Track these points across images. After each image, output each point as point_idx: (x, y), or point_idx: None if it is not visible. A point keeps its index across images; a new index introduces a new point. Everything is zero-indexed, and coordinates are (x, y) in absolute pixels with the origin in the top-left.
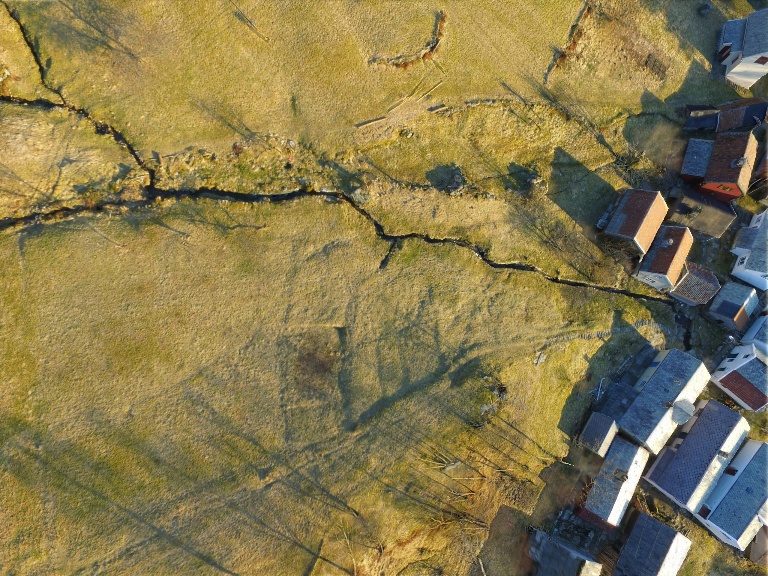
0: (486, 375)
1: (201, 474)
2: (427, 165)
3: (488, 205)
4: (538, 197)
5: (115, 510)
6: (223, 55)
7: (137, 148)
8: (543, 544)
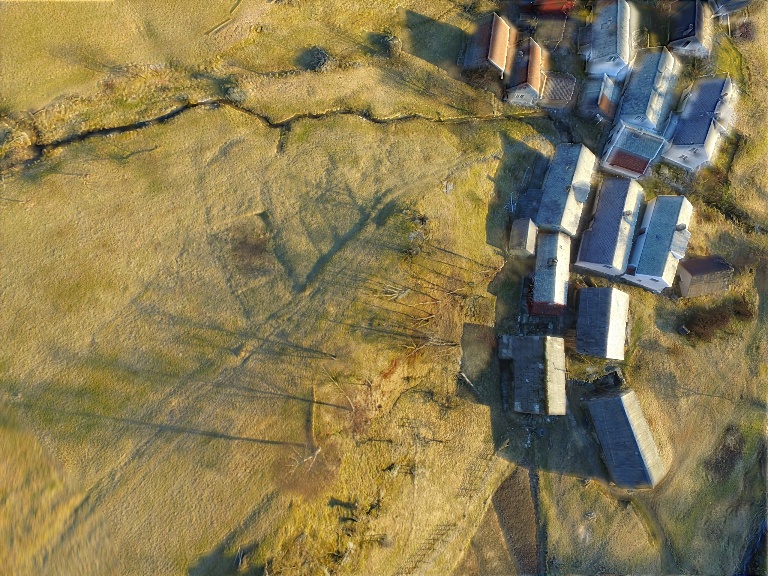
0: (404, 210)
1: (181, 370)
2: (286, 52)
3: (354, 72)
4: (395, 51)
5: (113, 423)
6: (53, 2)
7: (5, 113)
8: (511, 343)
